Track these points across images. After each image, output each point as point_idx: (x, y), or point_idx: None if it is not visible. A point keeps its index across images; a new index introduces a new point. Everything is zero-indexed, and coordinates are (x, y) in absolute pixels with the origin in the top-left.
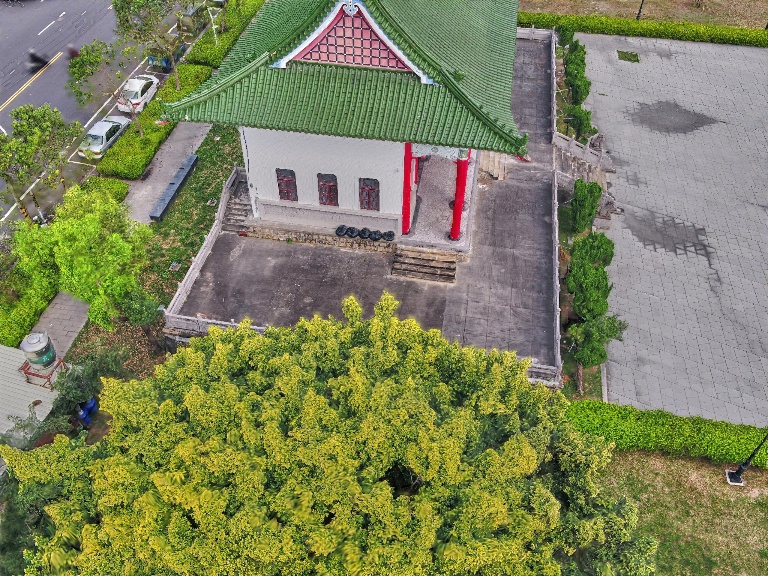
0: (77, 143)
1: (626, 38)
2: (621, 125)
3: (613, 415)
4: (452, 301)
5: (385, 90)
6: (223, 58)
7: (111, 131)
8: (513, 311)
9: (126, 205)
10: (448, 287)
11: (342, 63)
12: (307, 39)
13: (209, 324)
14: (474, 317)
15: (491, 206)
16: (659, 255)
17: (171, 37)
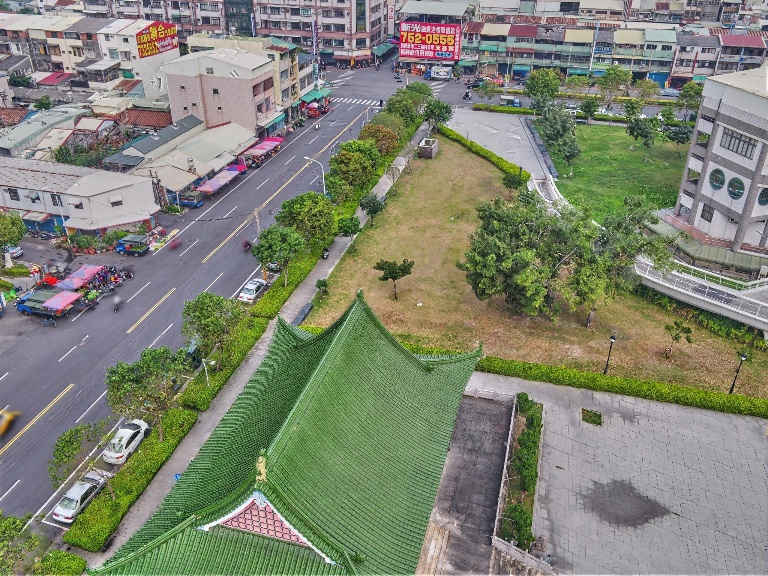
0: (57, 498)
1: (593, 393)
2: (571, 511)
3: None
4: None
5: (293, 564)
6: (212, 399)
7: (87, 492)
8: None
9: None
10: None
11: (258, 532)
12: (226, 516)
13: None
14: None
15: None
16: None
17: None
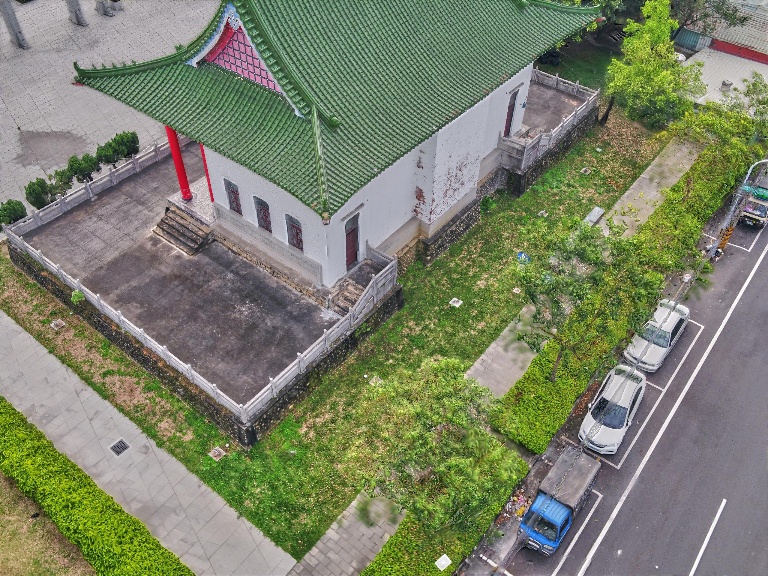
0: (697, 353)
1: None
2: None
3: None
4: None
5: None
6: None
7: None
8: None
9: (626, 45)
10: None
11: None
12: None
13: (571, 86)
14: None
15: None
16: None
17: (550, 481)
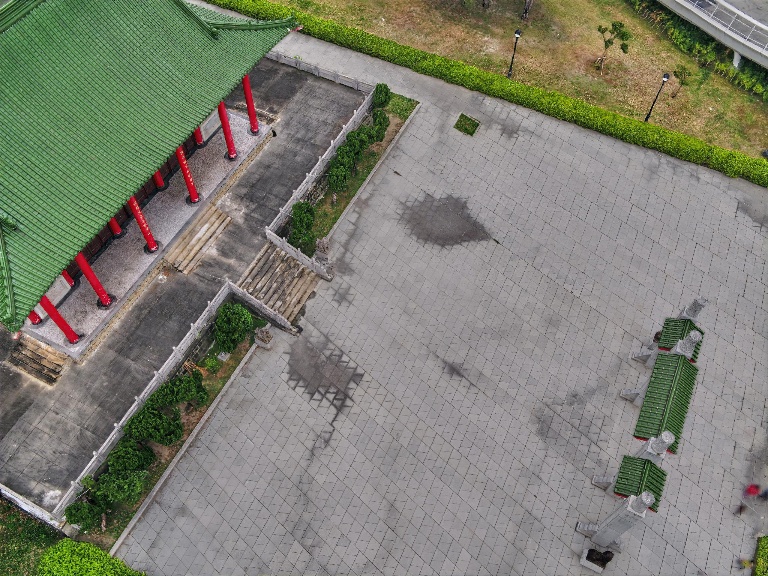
0: None
1: (485, 98)
2: (384, 220)
3: (95, 567)
4: (36, 406)
5: None
6: None
7: None
8: (80, 433)
9: None
10: (44, 389)
11: None
12: None
13: None
14: (42, 430)
15: (152, 304)
16: (293, 395)
17: None
